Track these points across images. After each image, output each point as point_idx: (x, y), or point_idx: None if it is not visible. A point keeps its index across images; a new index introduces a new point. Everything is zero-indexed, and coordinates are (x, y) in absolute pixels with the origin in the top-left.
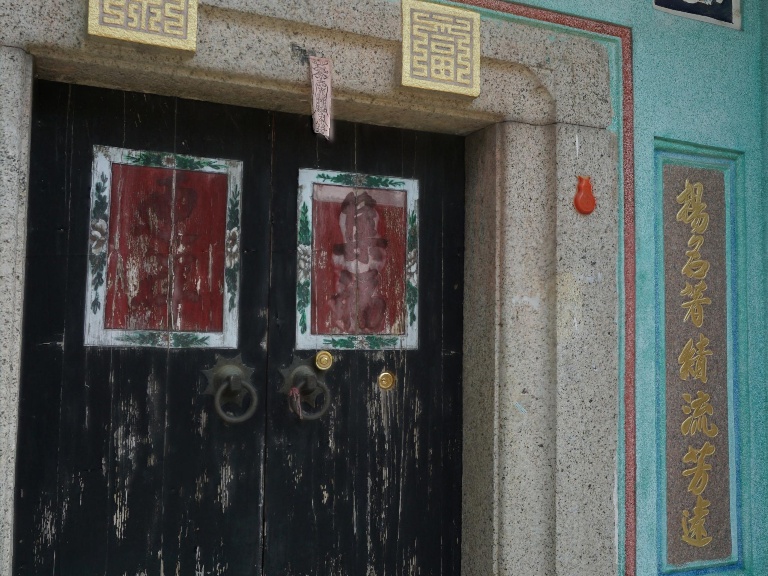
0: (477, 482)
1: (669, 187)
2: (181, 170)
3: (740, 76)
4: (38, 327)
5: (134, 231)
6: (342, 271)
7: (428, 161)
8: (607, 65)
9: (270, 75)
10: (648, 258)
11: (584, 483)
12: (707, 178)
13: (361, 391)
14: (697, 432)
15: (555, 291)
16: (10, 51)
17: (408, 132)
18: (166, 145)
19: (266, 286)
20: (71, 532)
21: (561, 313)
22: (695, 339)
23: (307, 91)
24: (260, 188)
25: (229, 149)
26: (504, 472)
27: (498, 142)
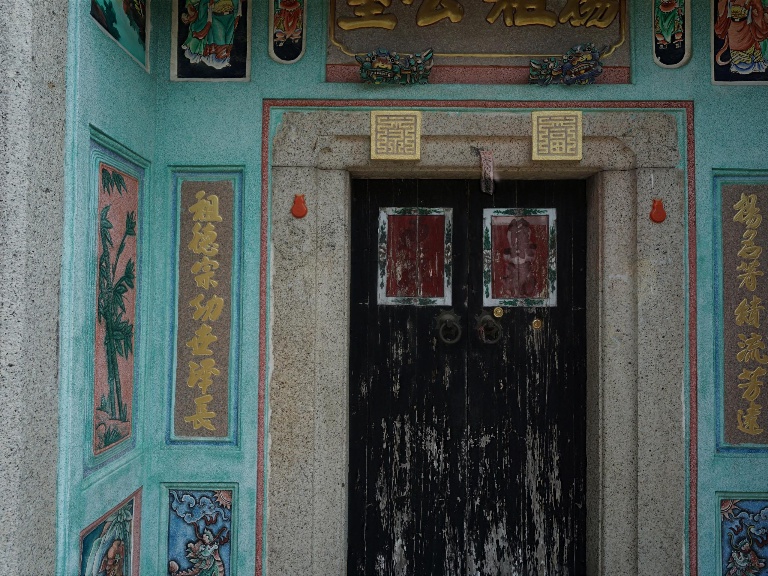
0: (592, 384)
1: (727, 200)
2: (421, 215)
3: None
4: (357, 296)
5: (399, 248)
6: (509, 263)
7: (562, 197)
8: (676, 127)
9: (460, 164)
10: (706, 247)
11: (658, 386)
12: (760, 191)
13: (522, 330)
14: (750, 360)
15: (637, 270)
16: (339, 171)
17: (549, 181)
18: (413, 203)
19: (466, 273)
20: (374, 393)
21: (641, 284)
22: (749, 299)
23: (480, 170)
24: (462, 221)
25: (445, 202)
26: (604, 377)
27: (600, 183)
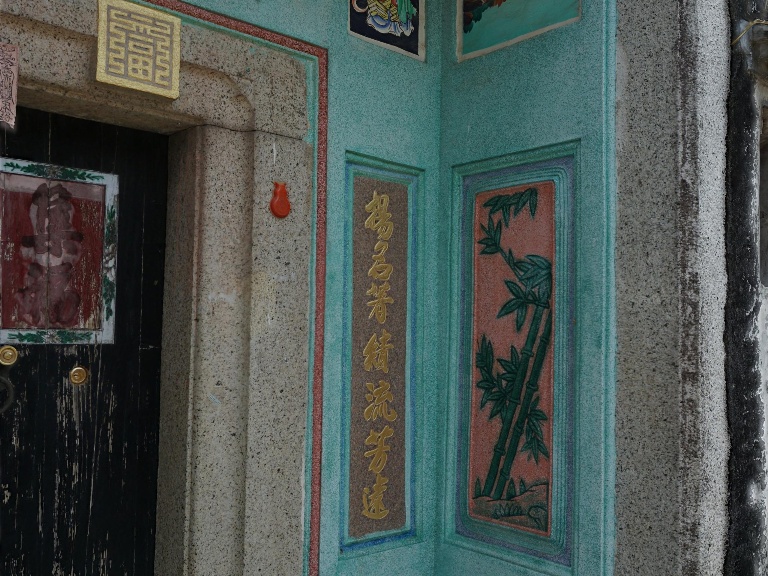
0: (171, 472)
1: (359, 197)
2: None
3: (423, 102)
4: None
5: None
6: (31, 264)
7: (129, 157)
8: (305, 81)
9: None
10: (337, 260)
11: (273, 468)
12: (393, 191)
13: (50, 386)
14: (378, 417)
15: (250, 289)
16: None
17: (108, 127)
18: None
19: None
20: None
21: (255, 309)
22: (378, 334)
23: None
24: None
25: None
26: (196, 461)
27: (198, 144)
